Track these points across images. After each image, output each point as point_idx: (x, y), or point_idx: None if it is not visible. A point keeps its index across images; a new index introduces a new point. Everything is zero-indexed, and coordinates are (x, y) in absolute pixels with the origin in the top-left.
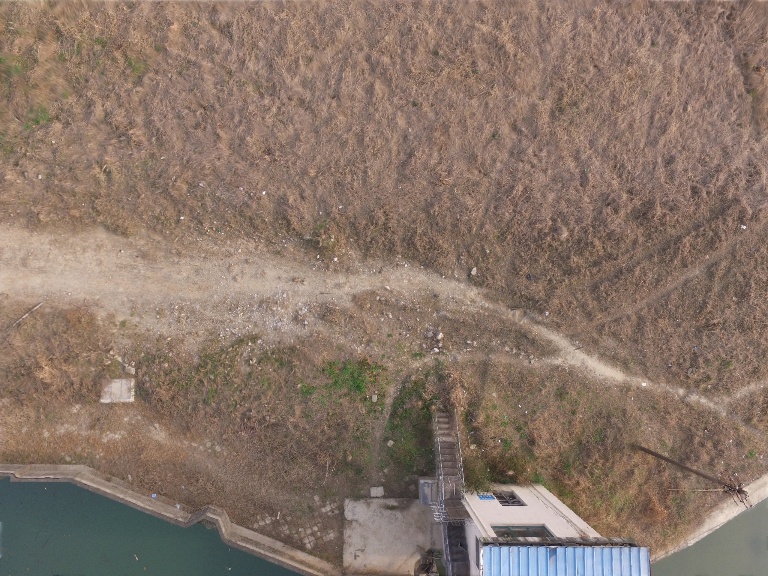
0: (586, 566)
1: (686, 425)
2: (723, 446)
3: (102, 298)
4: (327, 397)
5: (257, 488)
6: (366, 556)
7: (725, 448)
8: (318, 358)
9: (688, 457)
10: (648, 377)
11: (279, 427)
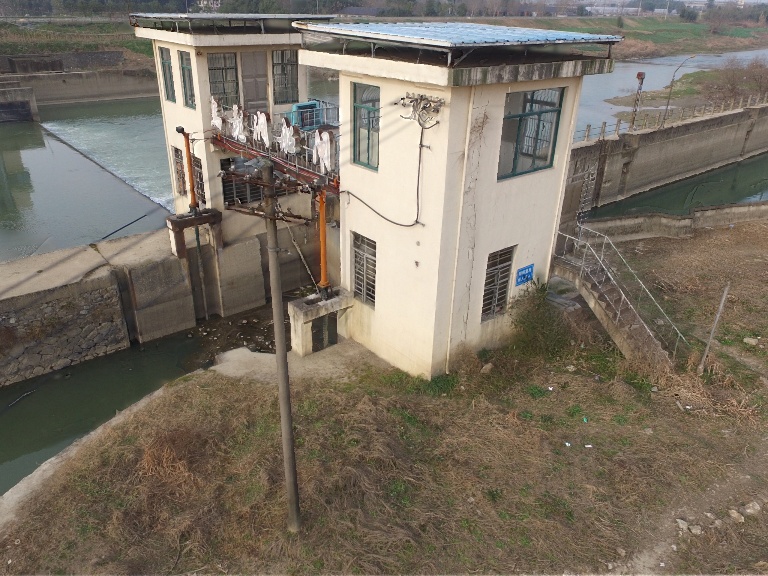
0: None
1: None
2: None
3: None
4: None
5: None
6: None
7: None
8: None
9: None
10: None
11: None
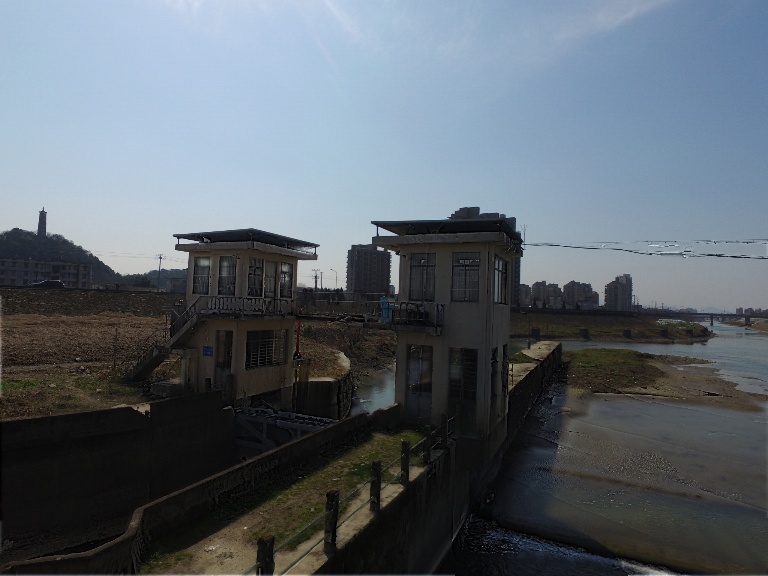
0: None
1: None
2: None
3: None
4: None
5: None
6: None
7: None
8: None
9: None
10: None
11: None
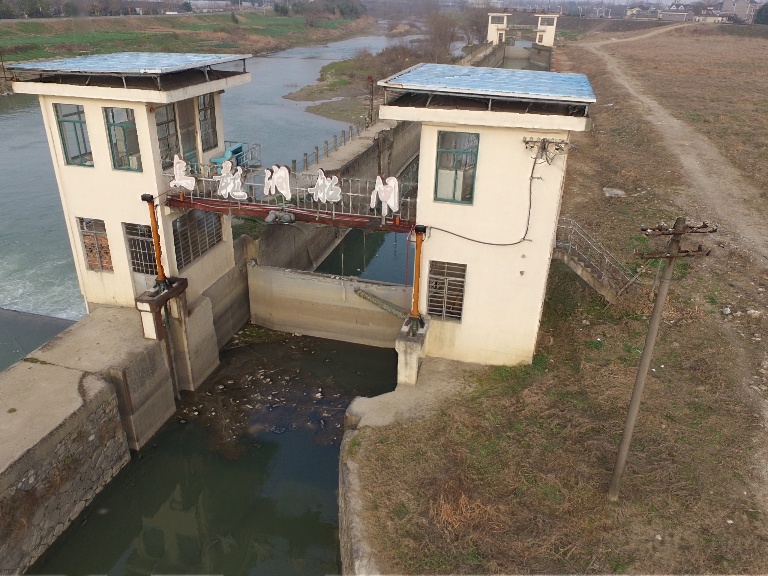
0: None
1: None
2: None
3: (698, 188)
4: None
5: None
6: None
7: None
8: (682, 247)
9: None
10: None
11: None
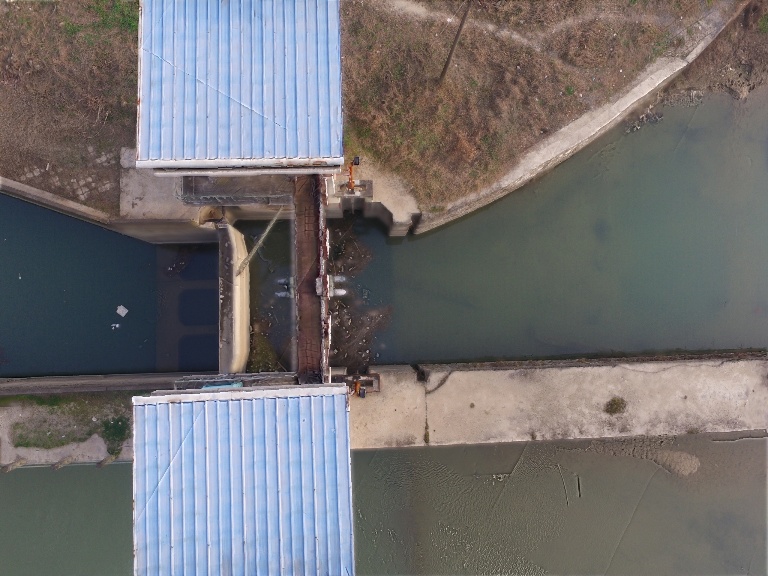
0: (264, 8)
1: (496, 62)
2: (537, 83)
3: None
4: (94, 36)
5: (23, 139)
6: (145, 204)
7: (540, 85)
8: None
9: (499, 94)
10: (454, 12)
11: (45, 74)
